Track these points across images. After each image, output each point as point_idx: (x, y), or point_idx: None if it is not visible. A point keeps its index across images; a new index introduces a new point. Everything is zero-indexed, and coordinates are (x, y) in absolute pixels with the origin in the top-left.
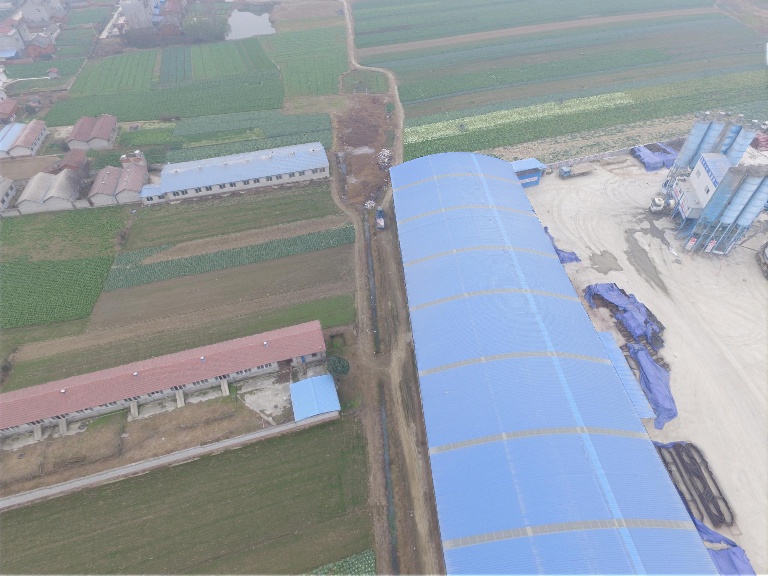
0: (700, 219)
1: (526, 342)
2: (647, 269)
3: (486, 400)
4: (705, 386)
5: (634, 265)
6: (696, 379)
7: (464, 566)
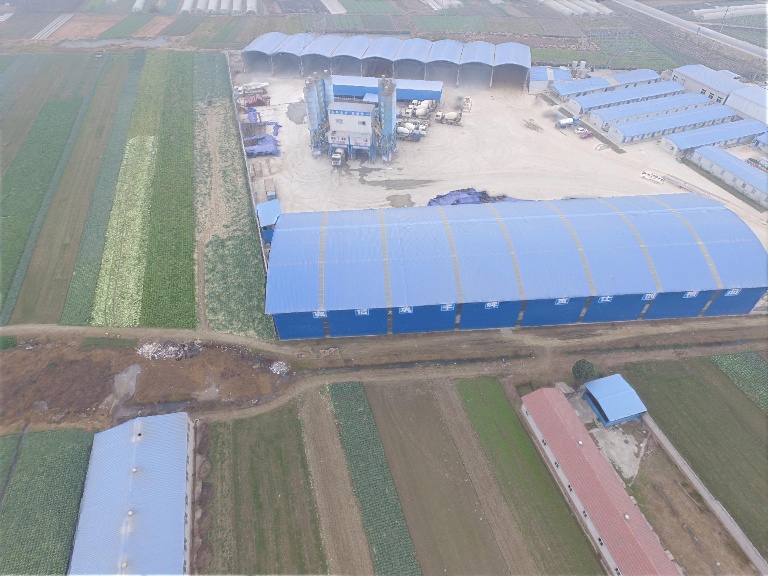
0: (387, 137)
1: (557, 225)
2: (408, 184)
3: (616, 252)
4: (515, 186)
5: (404, 188)
6: (510, 188)
7: (730, 278)
